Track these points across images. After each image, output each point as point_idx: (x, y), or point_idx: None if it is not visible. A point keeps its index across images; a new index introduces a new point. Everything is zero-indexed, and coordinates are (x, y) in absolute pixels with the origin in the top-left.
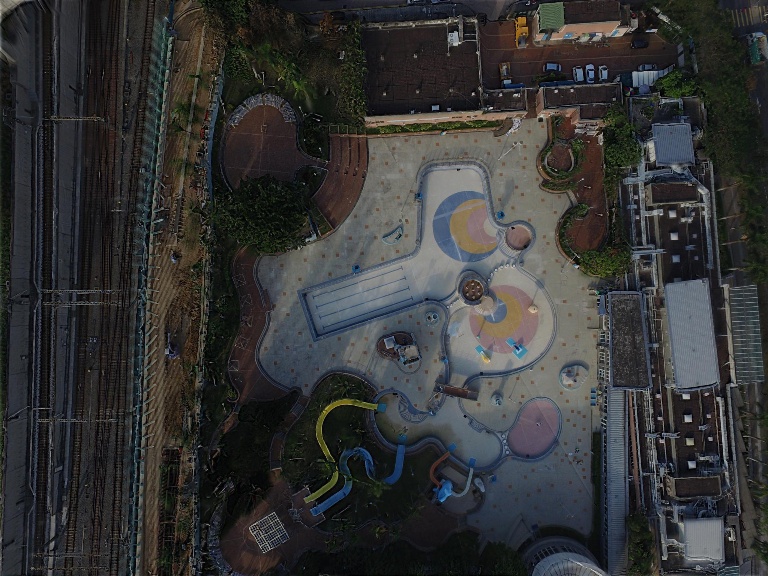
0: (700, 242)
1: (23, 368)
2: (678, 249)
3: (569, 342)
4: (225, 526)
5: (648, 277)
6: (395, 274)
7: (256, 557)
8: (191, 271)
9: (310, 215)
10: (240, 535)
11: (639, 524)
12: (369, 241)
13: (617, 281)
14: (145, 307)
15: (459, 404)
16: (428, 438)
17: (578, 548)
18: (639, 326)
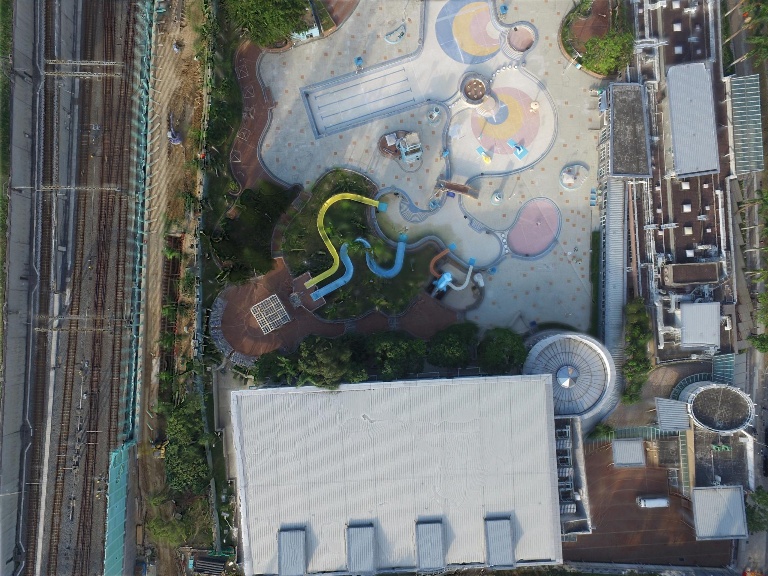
0: (703, 34)
1: (26, 146)
2: (681, 41)
3: (570, 143)
4: (227, 311)
5: (650, 72)
6: (397, 75)
7: (257, 343)
8: (194, 60)
9: (313, 6)
10: (241, 322)
11: (636, 308)
12: (372, 40)
13: (619, 77)
14: (148, 96)
15: (460, 205)
16: (428, 236)
17: (575, 334)
18: (640, 116)
